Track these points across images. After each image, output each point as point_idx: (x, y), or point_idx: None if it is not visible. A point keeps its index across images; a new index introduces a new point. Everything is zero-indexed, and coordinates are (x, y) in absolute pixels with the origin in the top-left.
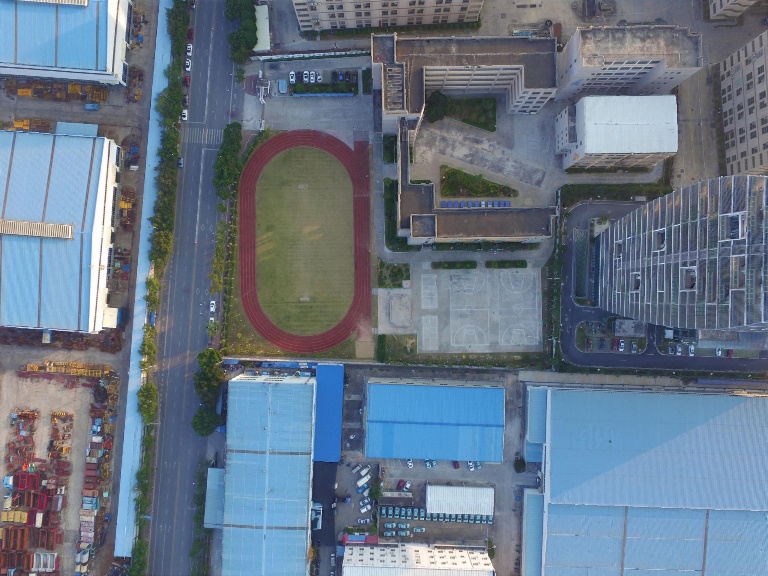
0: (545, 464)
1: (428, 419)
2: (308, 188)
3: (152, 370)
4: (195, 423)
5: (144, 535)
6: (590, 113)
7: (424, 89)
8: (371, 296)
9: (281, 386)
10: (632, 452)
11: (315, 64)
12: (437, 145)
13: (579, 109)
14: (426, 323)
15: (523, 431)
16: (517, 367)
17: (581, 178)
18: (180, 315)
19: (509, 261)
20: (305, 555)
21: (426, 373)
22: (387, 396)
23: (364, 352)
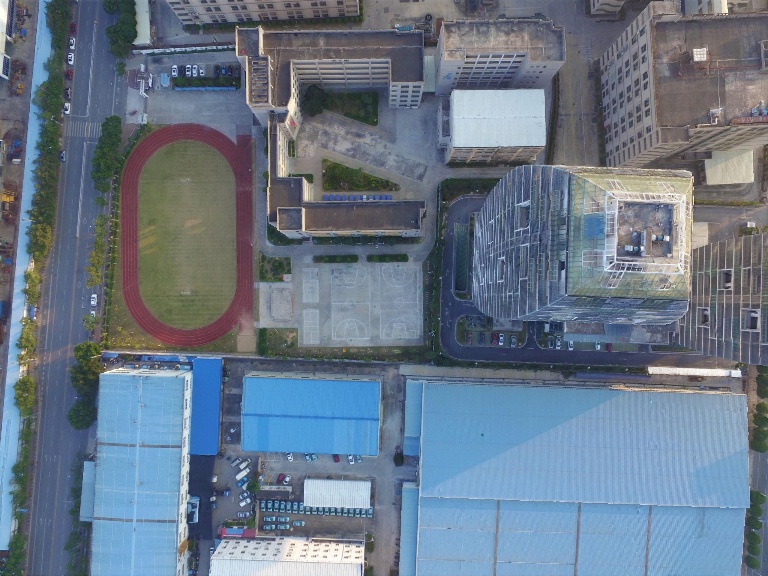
0: (420, 457)
1: (303, 412)
2: (190, 182)
3: (33, 363)
4: (70, 416)
5: (24, 528)
6: (458, 107)
7: (291, 82)
8: (253, 290)
9: (152, 379)
10: (504, 445)
11: (198, 58)
12: (319, 139)
13: (451, 103)
14: (307, 317)
15: (403, 425)
16: (396, 361)
17: (463, 172)
18: (62, 308)
19: (390, 255)
20: (175, 548)
21: (307, 367)
22: (263, 389)
23: (246, 346)
